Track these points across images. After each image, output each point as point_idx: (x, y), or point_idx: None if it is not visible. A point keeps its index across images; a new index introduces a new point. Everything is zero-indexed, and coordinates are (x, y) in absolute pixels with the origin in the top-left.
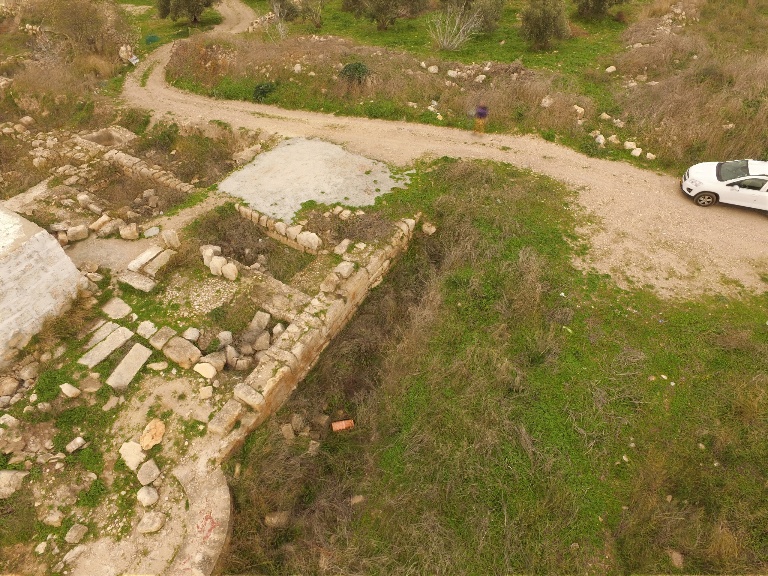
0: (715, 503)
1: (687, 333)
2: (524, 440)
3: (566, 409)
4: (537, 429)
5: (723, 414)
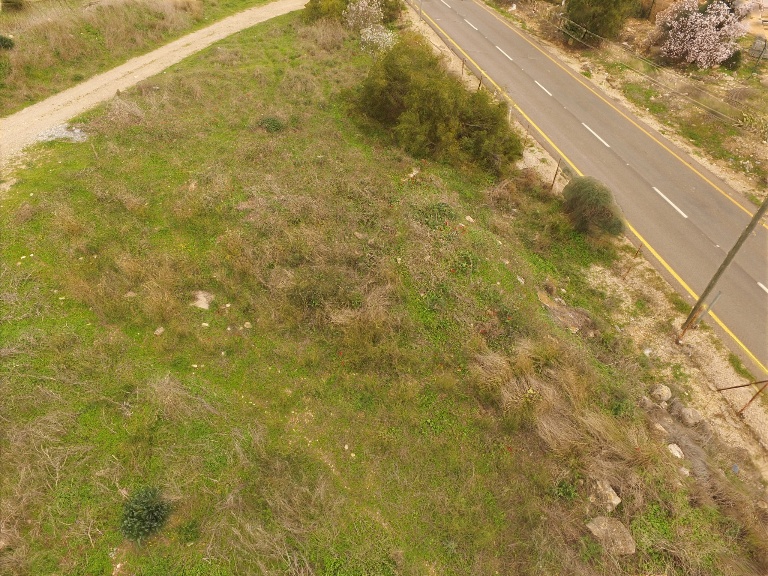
0: (111, 264)
1: (1, 232)
2: (1, 352)
3: (0, 321)
4: (1, 344)
5: (69, 240)
